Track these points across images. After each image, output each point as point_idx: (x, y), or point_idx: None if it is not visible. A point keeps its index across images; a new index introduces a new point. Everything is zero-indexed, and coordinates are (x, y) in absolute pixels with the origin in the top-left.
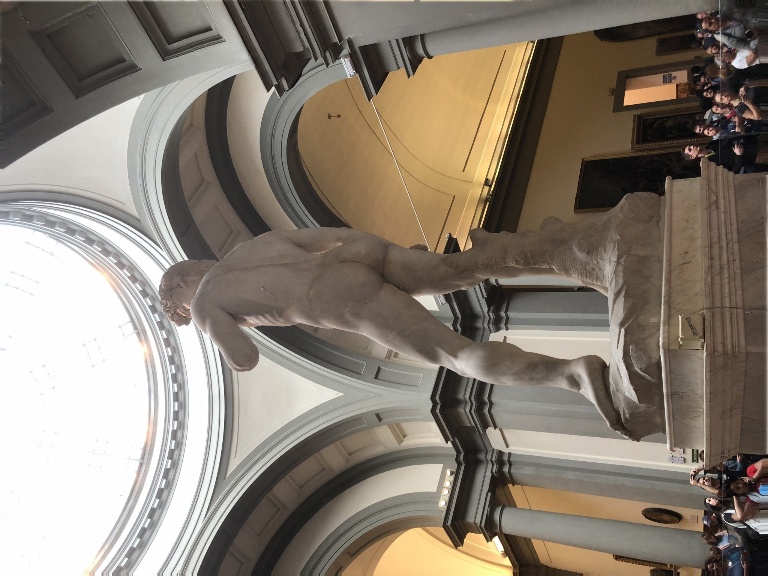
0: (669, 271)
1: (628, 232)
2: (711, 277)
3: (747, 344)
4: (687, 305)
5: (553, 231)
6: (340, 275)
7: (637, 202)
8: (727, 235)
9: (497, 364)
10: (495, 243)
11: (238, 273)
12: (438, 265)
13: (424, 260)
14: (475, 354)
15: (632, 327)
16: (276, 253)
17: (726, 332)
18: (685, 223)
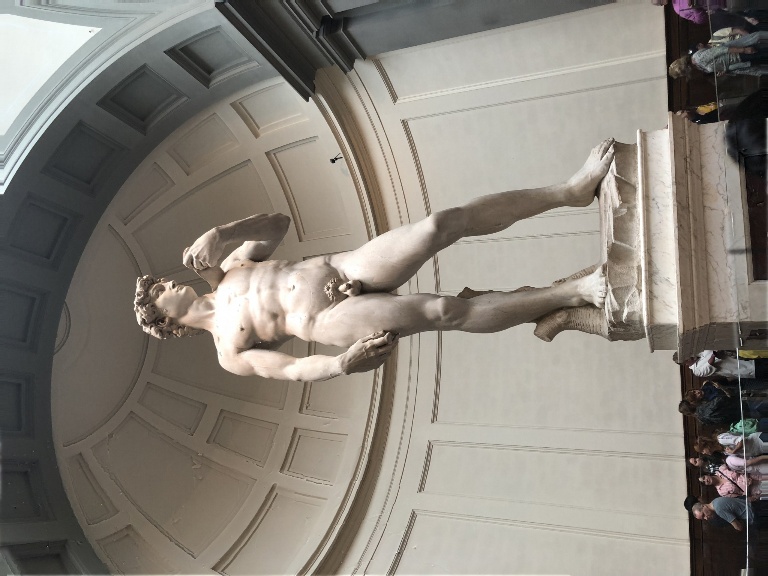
0: None
1: None
2: None
3: None
4: None
5: None
6: None
7: None
8: None
9: None
10: None
11: None
12: None
13: None
14: None
15: None
16: None
17: None
18: None
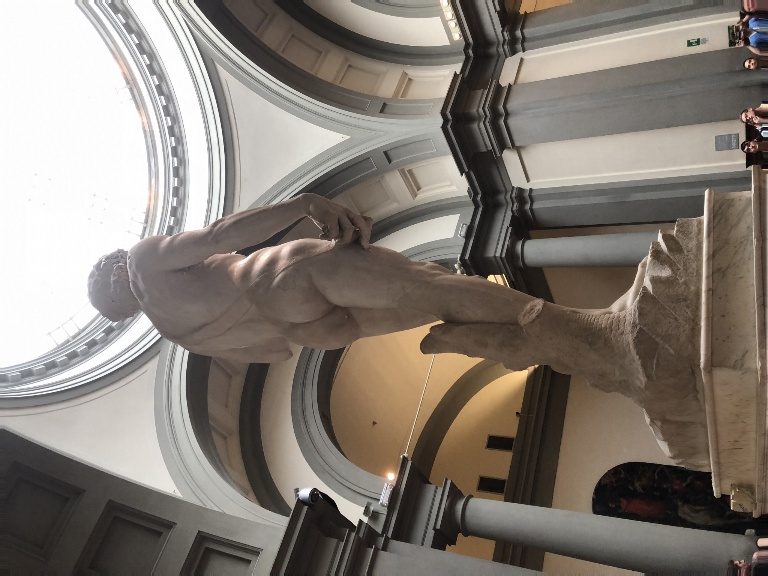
0: (717, 456)
1: (657, 407)
2: None
3: None
4: (738, 475)
5: (548, 358)
6: None
7: (662, 389)
8: None
9: None
10: (478, 355)
11: None
12: None
13: None
14: None
15: None
16: None
17: None
18: (734, 417)
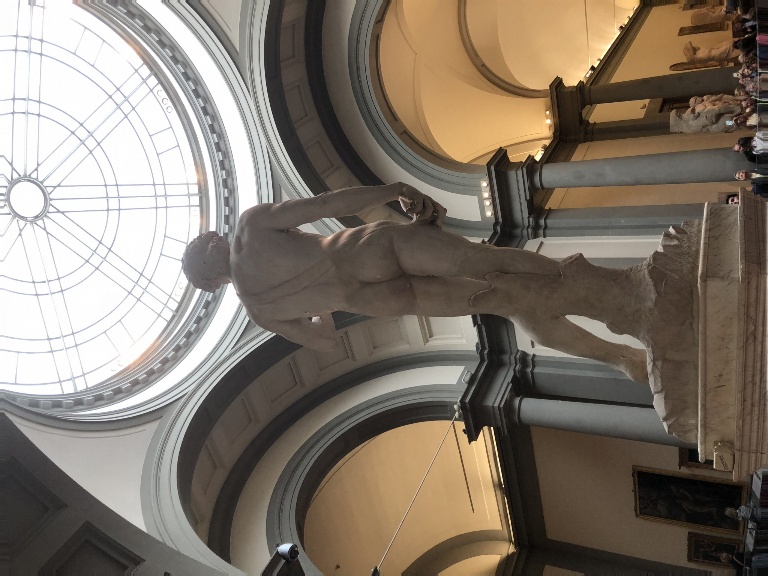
0: (704, 396)
1: (661, 338)
2: (742, 420)
3: (767, 463)
4: (720, 427)
5: (578, 298)
6: (375, 309)
7: (667, 307)
8: (762, 369)
9: (553, 347)
10: (520, 302)
11: (273, 306)
12: (459, 274)
13: (443, 270)
14: (529, 334)
15: (674, 426)
16: (288, 275)
17: (751, 460)
18: (720, 341)
